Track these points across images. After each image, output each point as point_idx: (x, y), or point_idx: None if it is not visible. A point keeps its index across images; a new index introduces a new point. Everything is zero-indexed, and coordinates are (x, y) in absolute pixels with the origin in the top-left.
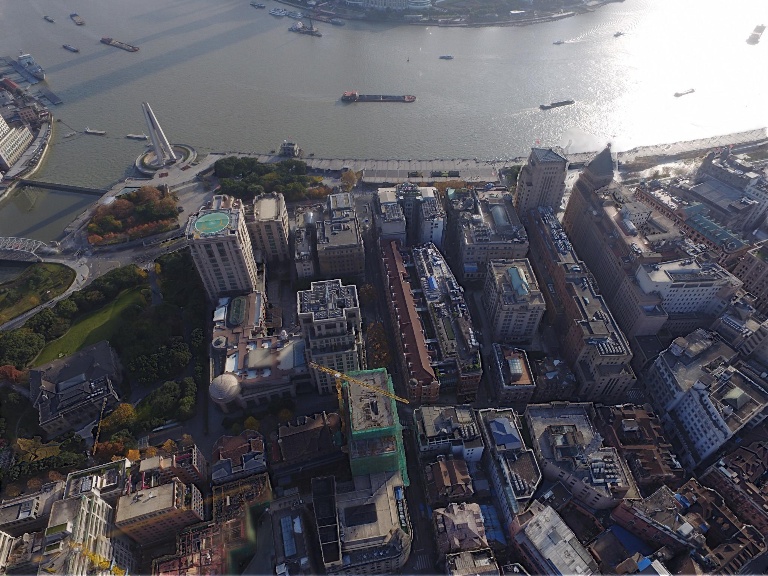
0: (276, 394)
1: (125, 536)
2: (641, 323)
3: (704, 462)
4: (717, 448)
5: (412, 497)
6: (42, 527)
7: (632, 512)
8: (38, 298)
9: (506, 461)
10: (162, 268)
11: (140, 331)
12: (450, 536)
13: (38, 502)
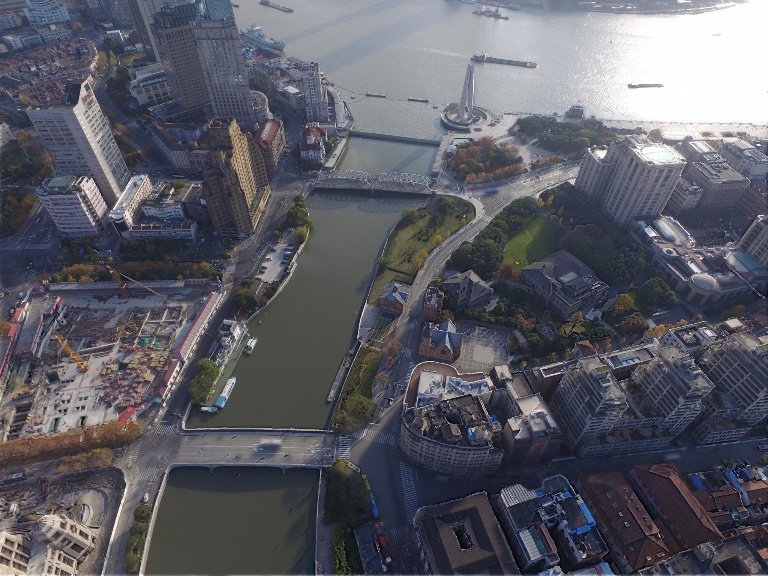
0: (742, 291)
1: None
2: None
3: None
4: None
5: None
6: None
7: None
8: (457, 221)
9: None
10: (553, 200)
11: (586, 244)
12: None
13: None
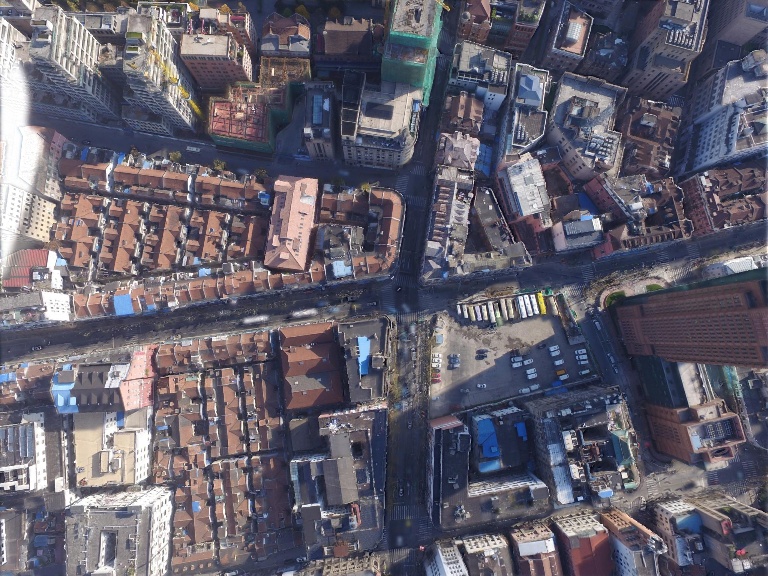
0: None
1: (188, 72)
2: (735, 24)
3: (693, 173)
4: (712, 162)
5: (428, 123)
6: (121, 45)
7: (602, 183)
8: None
9: (519, 114)
10: None
11: None
12: (446, 153)
13: (115, 20)
